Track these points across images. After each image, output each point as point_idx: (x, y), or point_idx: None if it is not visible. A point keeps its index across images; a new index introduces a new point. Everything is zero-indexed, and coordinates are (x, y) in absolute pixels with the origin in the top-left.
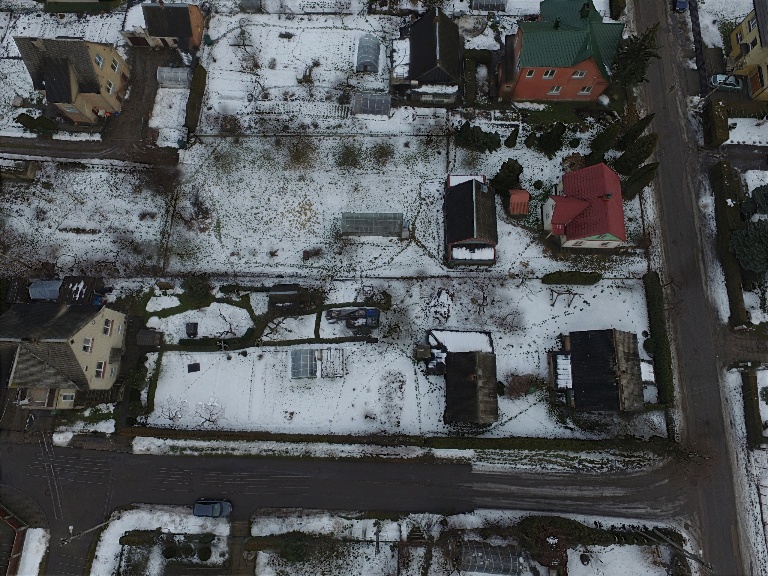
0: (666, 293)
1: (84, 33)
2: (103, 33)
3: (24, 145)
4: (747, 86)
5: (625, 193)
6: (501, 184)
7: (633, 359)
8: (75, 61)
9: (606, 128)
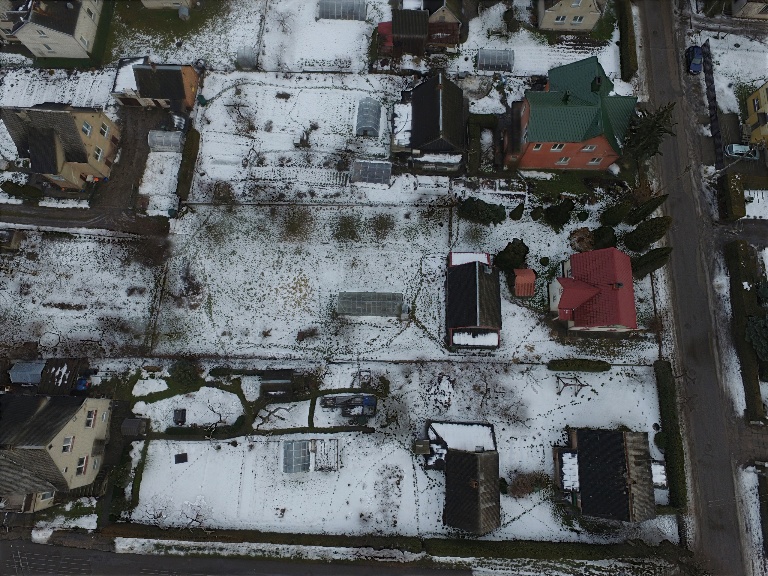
0: (678, 382)
1: (74, 91)
2: (93, 91)
3: (9, 212)
4: (764, 156)
5: (636, 272)
6: (506, 263)
7: (644, 462)
8: (61, 131)
9: (616, 204)
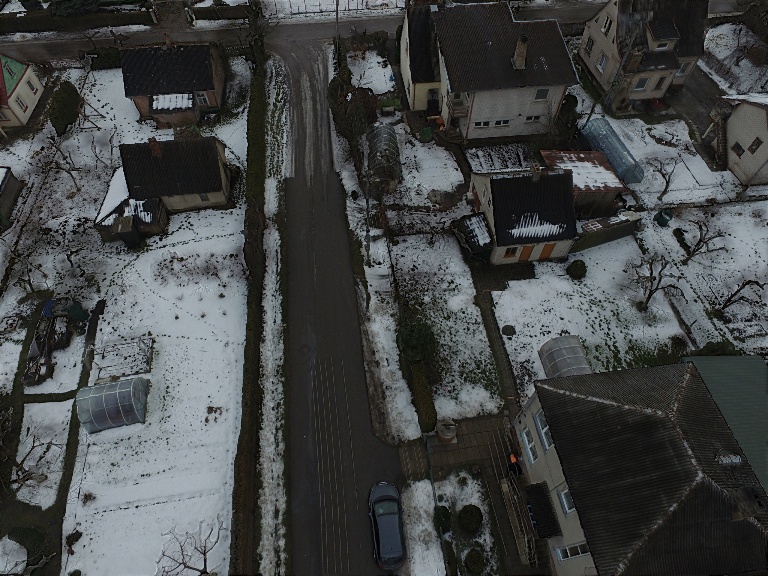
0: None
1: None
2: None
3: None
4: None
5: None
6: None
7: None
8: None
9: None
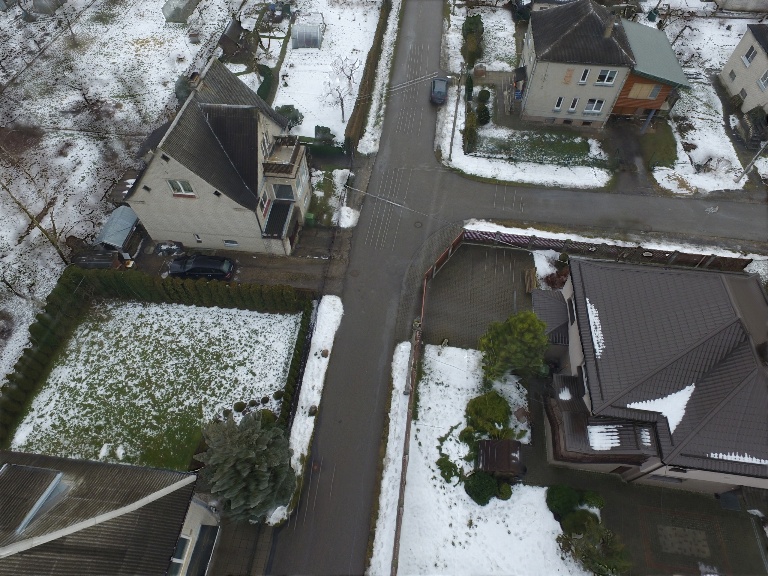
0: None
1: None
2: None
3: None
4: None
5: None
6: None
7: None
8: None
9: None
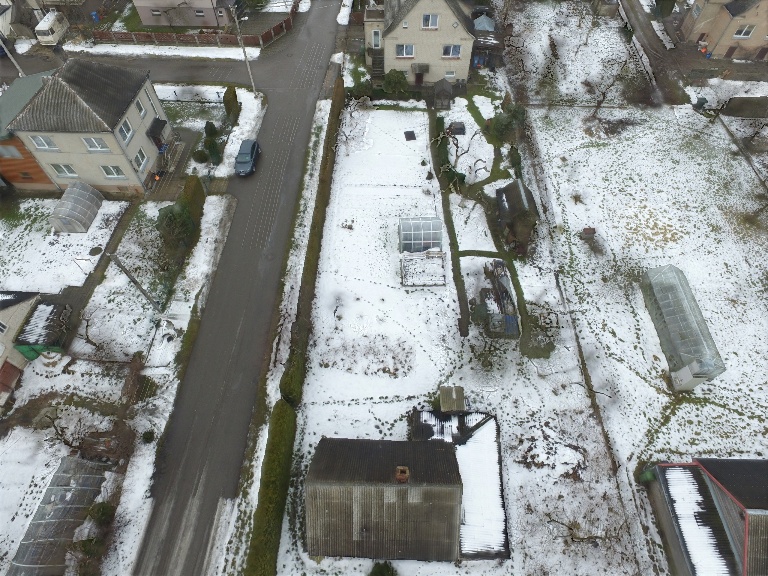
0: None
1: None
2: None
3: (634, 7)
4: None
5: None
6: None
7: None
8: None
9: None
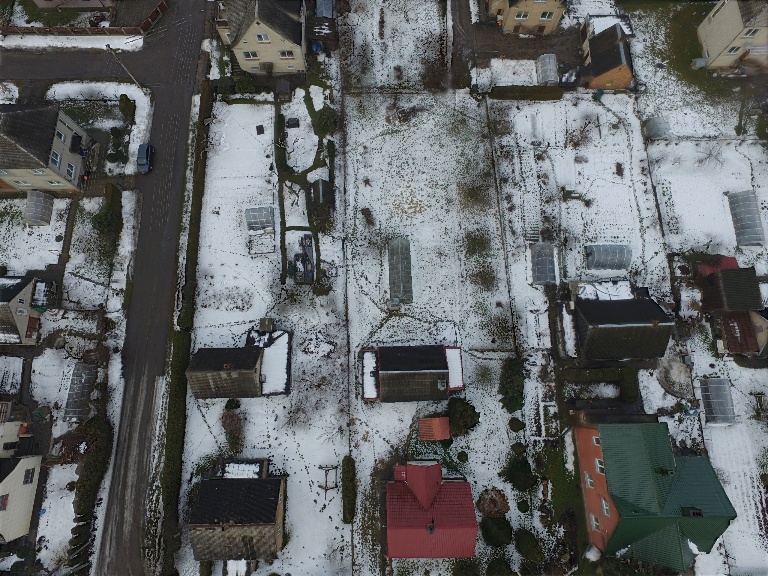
0: None
1: None
2: (591, 4)
3: None
4: None
5: (460, 569)
6: None
7: (248, 550)
8: None
9: None
